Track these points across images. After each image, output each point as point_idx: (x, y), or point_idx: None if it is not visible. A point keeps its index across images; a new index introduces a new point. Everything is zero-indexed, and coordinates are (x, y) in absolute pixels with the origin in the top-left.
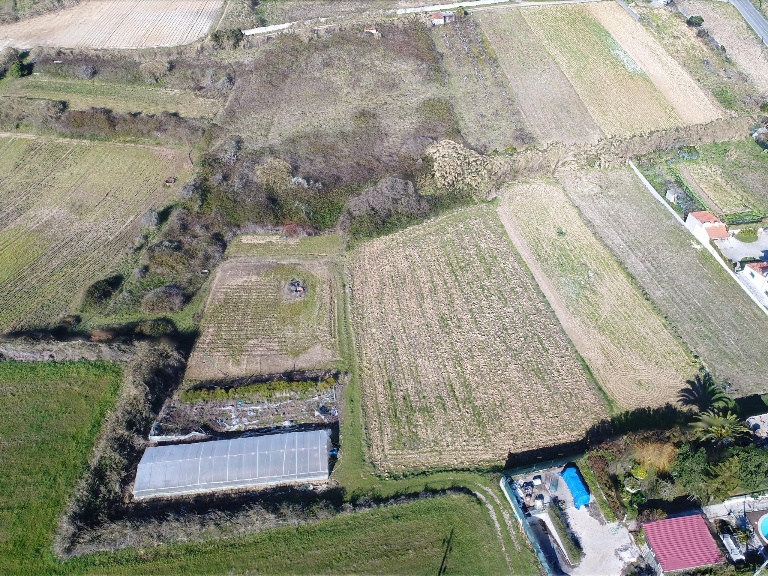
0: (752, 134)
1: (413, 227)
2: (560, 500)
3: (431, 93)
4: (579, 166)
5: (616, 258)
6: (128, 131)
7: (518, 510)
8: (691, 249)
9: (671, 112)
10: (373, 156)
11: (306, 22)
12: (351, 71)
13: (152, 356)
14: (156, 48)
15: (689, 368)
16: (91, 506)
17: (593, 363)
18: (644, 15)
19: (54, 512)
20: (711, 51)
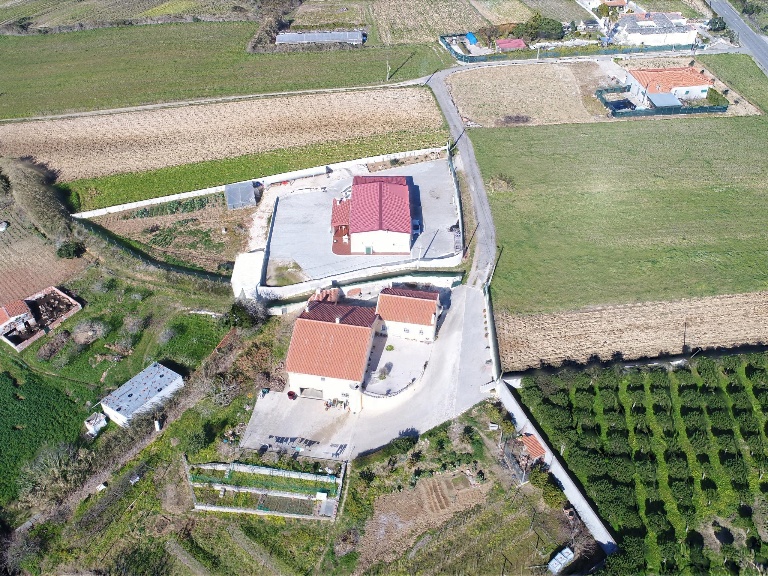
0: None
1: None
2: None
3: None
4: None
5: None
6: None
7: None
8: None
9: None
10: None
11: None
12: None
13: None
14: None
15: None
16: None
17: (492, 20)
18: None
19: None
20: None
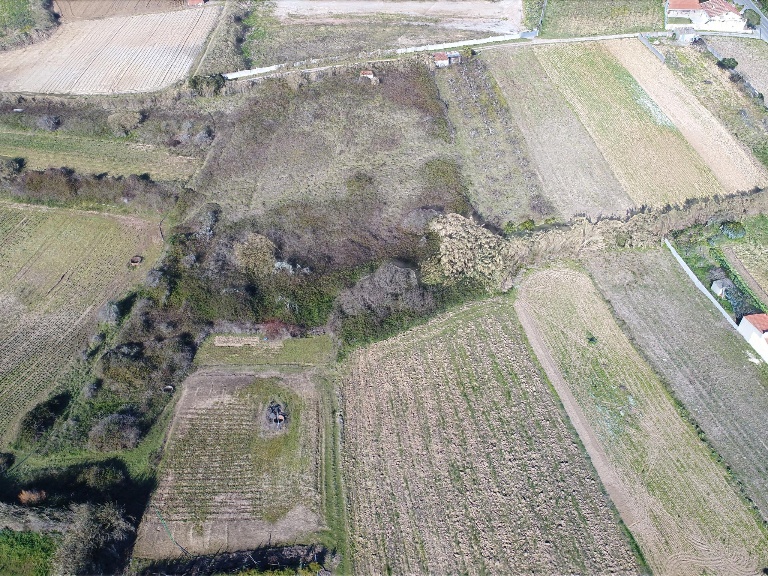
0: None
1: (416, 328)
2: None
3: (435, 151)
4: (607, 245)
5: (660, 377)
6: (91, 196)
7: None
8: (748, 364)
9: (708, 175)
10: (369, 231)
11: (296, 64)
12: (345, 124)
13: (90, 532)
14: (128, 94)
15: (765, 549)
16: None
17: (643, 540)
18: (670, 55)
19: None
20: (747, 99)
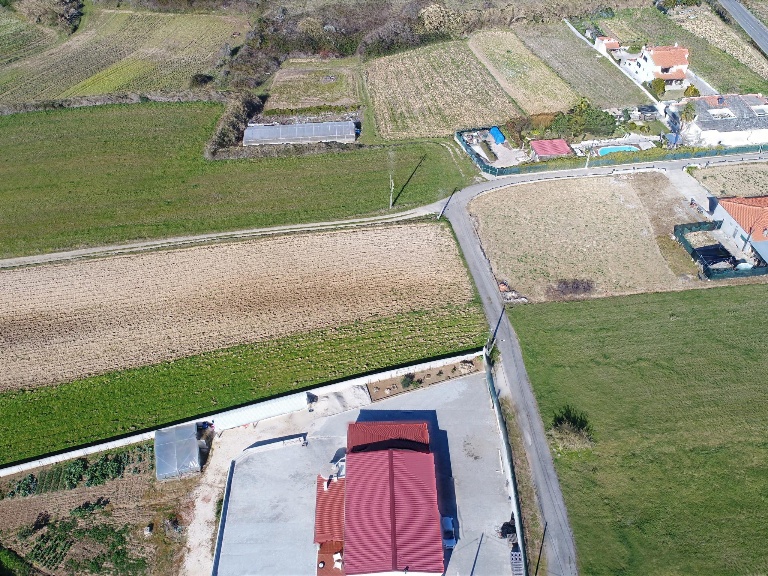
0: (655, 3)
1: (409, 51)
2: (488, 141)
3: None
4: (528, 22)
5: (544, 61)
6: (202, 6)
7: (463, 143)
8: (595, 57)
9: None
10: (381, 17)
11: None
12: None
13: (244, 94)
14: None
15: (577, 101)
16: (221, 144)
17: (518, 100)
18: None
19: (200, 148)
20: None
